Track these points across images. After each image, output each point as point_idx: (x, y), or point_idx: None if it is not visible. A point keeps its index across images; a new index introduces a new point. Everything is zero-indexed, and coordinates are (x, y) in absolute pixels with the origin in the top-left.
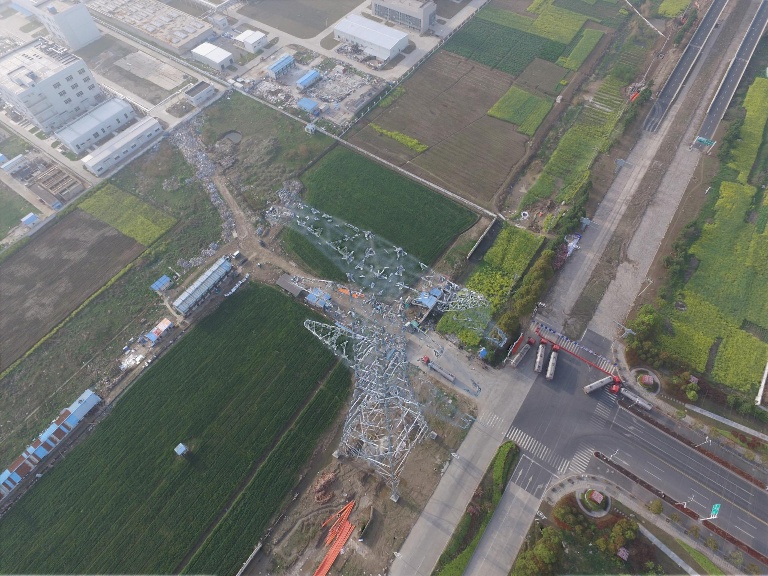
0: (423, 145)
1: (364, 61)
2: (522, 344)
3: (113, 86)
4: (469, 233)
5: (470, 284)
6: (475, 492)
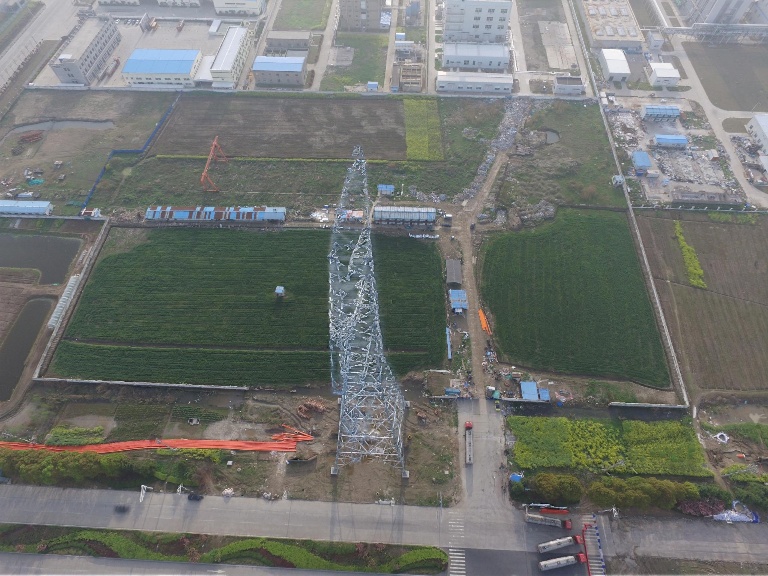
0: (703, 282)
1: (748, 166)
2: (558, 516)
3: (518, 37)
4: (641, 389)
5: (582, 423)
6: (377, 542)
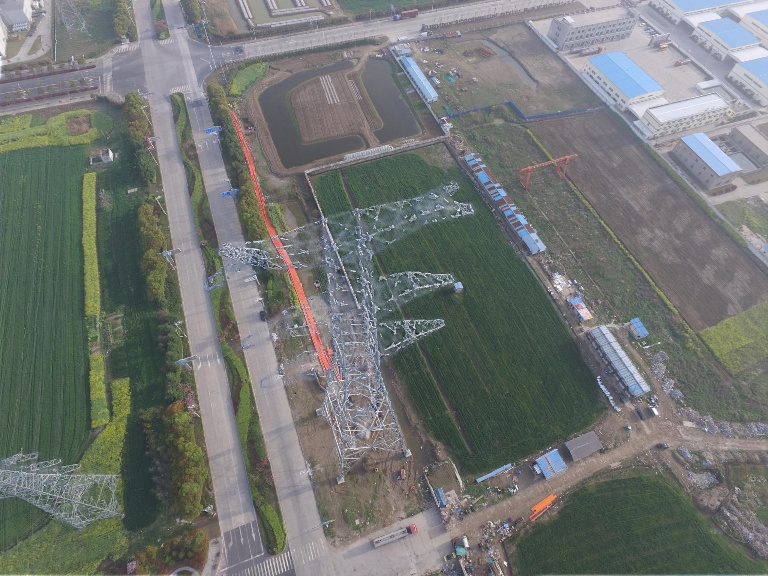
0: None
1: None
2: None
3: None
4: None
5: None
6: None
